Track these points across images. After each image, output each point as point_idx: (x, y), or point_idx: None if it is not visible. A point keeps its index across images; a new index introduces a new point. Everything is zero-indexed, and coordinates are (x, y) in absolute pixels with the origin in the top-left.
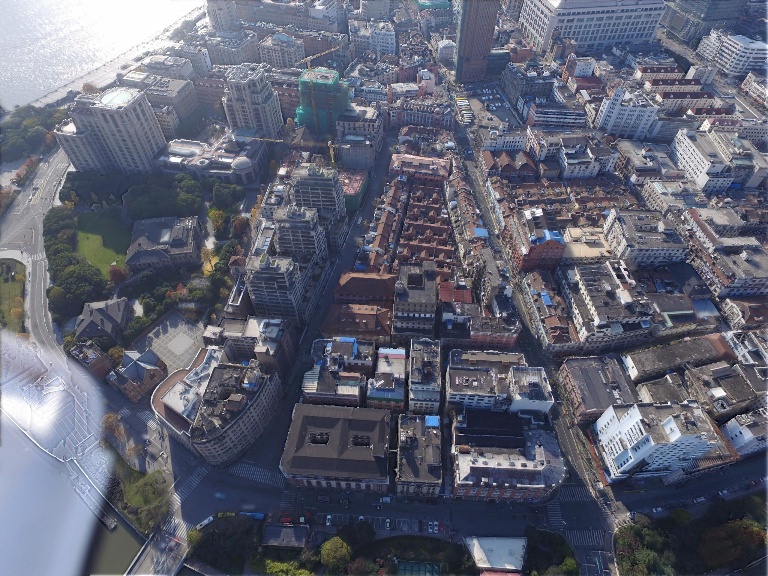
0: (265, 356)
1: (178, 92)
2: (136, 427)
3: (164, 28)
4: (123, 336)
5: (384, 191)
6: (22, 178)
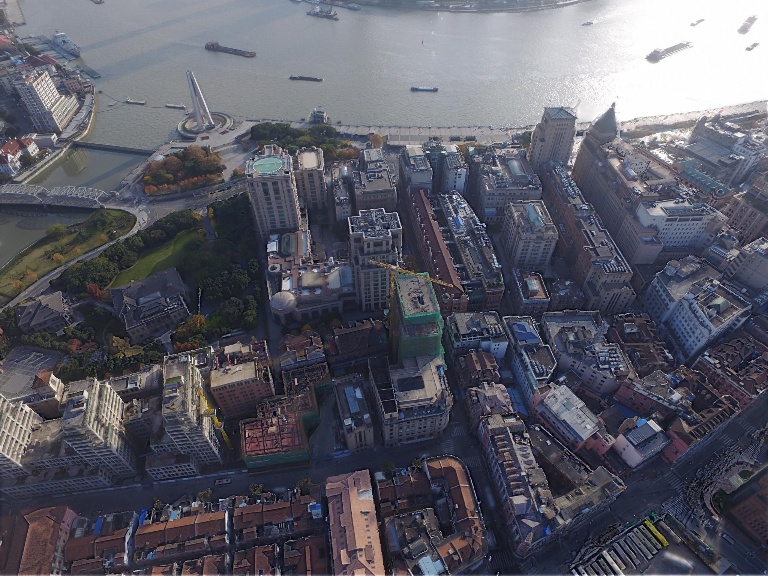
0: None
1: (367, 192)
2: None
3: (531, 124)
4: None
5: None
6: (239, 174)
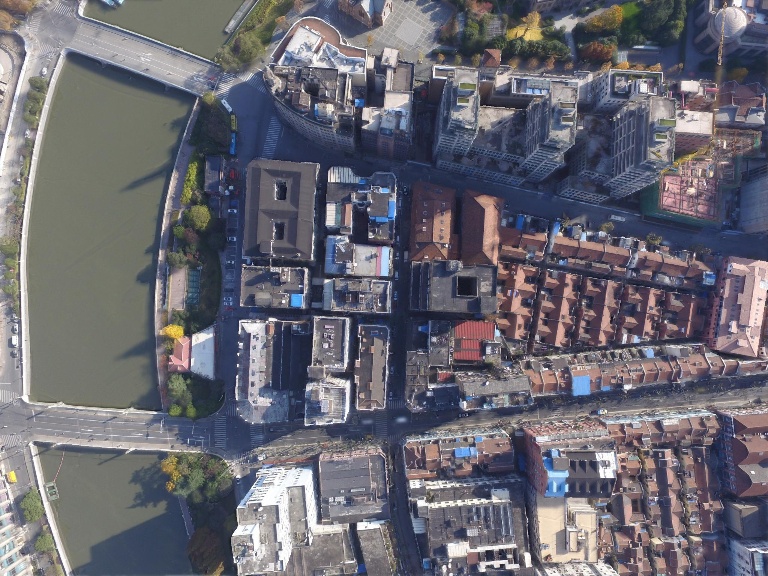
0: None
1: None
2: None
3: None
4: None
5: (681, 251)
6: None
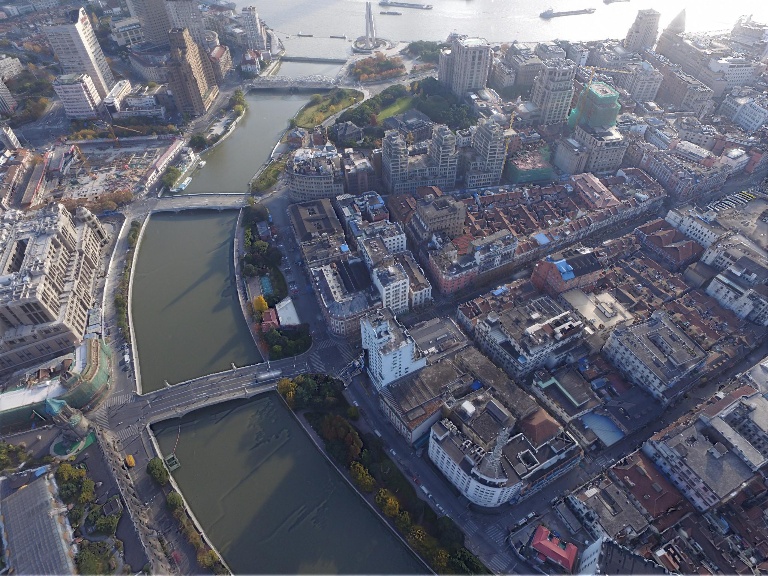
0: (346, 173)
1: (528, 65)
2: None
3: None
4: None
5: None
6: (416, 70)
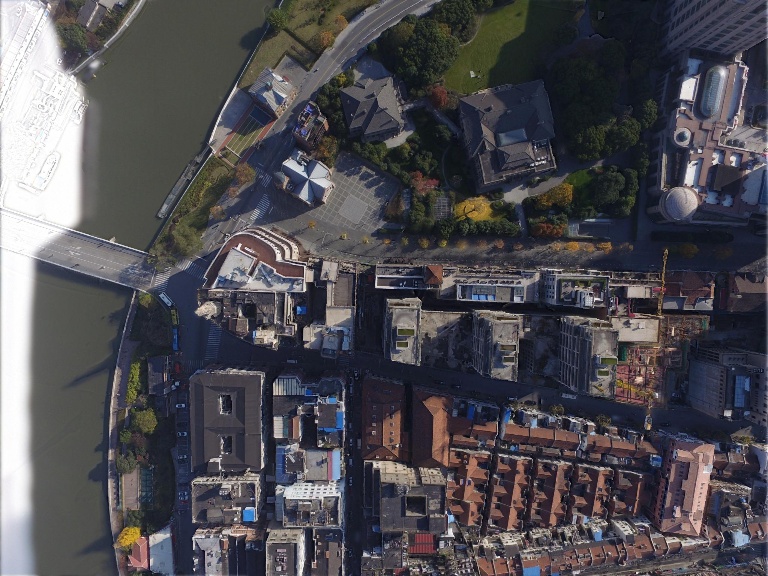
0: None
1: None
2: (252, 199)
3: None
4: (360, 137)
5: (630, 430)
6: None
